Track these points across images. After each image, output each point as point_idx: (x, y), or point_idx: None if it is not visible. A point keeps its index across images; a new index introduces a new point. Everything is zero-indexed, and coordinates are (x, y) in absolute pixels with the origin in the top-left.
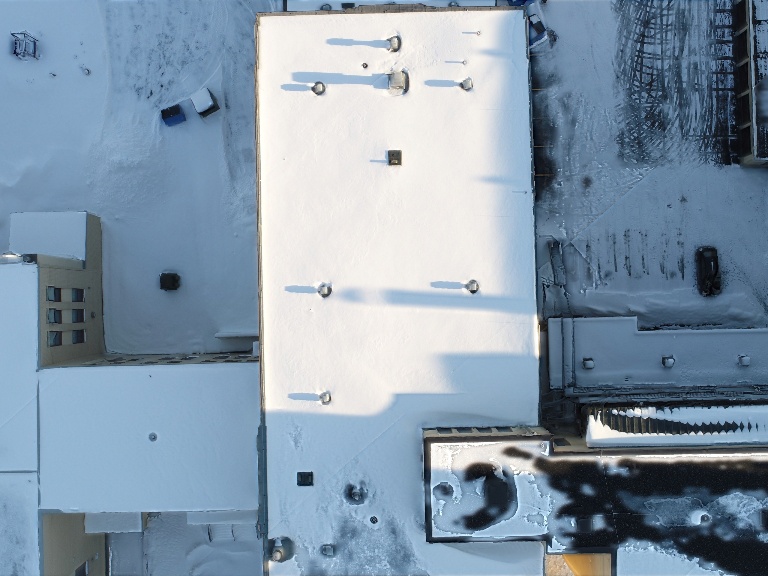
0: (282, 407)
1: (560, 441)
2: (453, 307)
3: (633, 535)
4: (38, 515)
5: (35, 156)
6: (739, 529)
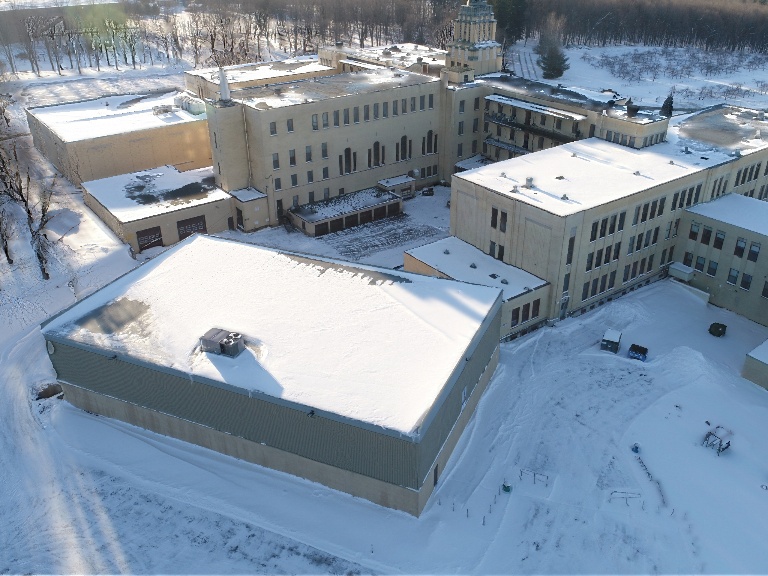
0: (694, 168)
1: (592, 133)
2: (589, 156)
3: None
4: None
5: (767, 417)
6: None
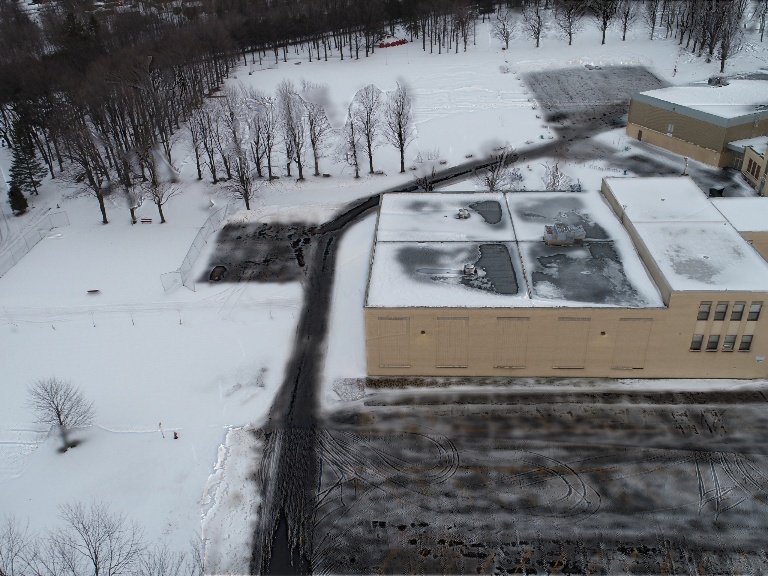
0: None
1: None
2: None
3: None
4: (738, 232)
5: None
6: None
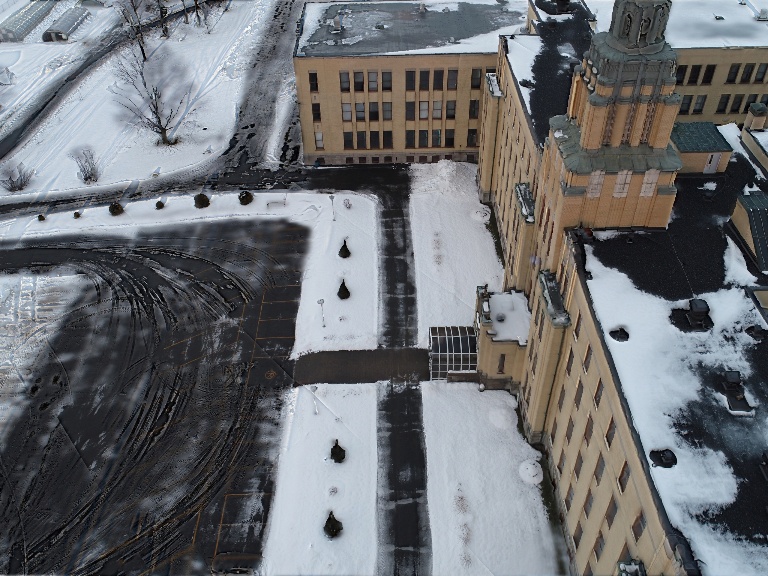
0: None
1: None
2: None
3: (549, 40)
4: None
5: None
6: (563, 65)
